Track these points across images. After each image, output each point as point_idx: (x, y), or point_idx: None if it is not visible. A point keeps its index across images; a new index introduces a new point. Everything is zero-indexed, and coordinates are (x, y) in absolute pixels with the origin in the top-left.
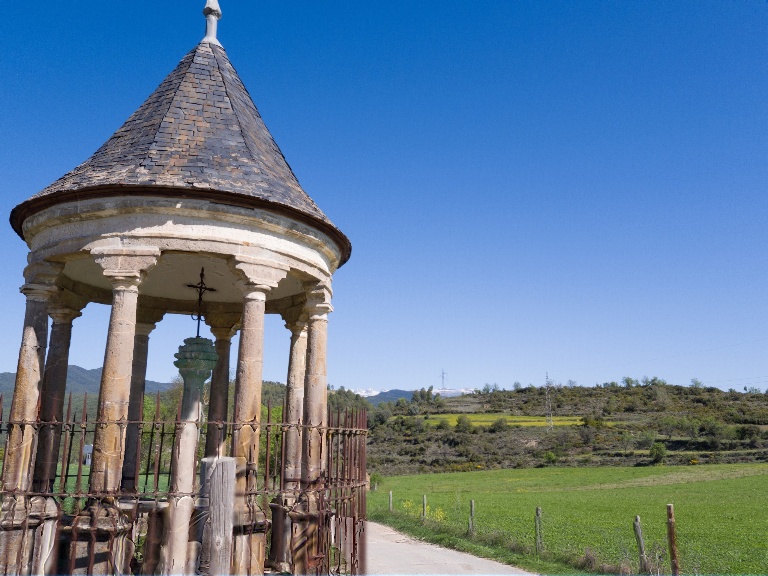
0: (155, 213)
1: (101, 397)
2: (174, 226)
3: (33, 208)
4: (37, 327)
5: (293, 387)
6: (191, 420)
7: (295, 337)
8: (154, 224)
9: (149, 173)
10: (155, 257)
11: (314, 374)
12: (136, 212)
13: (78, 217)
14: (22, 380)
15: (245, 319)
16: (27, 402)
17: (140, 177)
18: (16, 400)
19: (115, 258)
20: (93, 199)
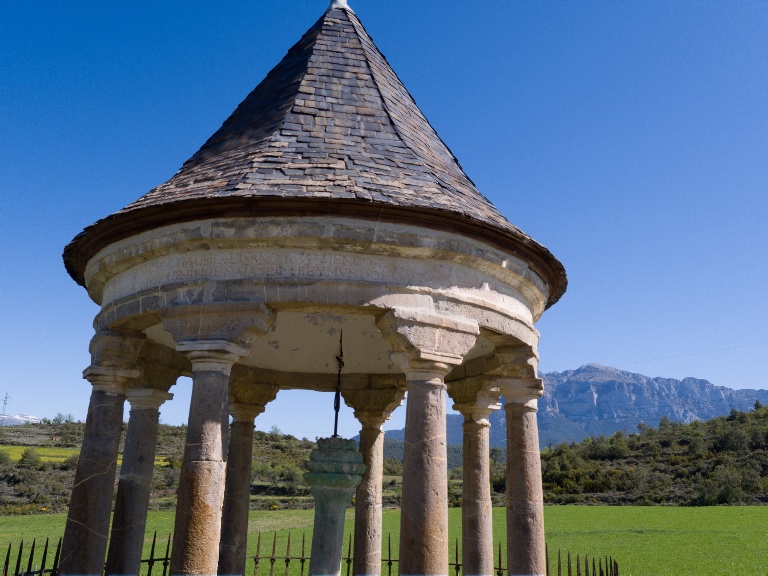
0: (473, 267)
1: (425, 575)
2: (490, 292)
3: (265, 207)
4: (223, 423)
5: (374, 502)
6: (338, 570)
7: (376, 432)
8: (471, 284)
9: (471, 204)
10: (476, 337)
11: (486, 500)
12: (452, 260)
13: (361, 246)
14: (205, 529)
15: (526, 437)
16: (212, 574)
17: (473, 209)
18: (193, 571)
19: (430, 330)
20: (405, 225)
